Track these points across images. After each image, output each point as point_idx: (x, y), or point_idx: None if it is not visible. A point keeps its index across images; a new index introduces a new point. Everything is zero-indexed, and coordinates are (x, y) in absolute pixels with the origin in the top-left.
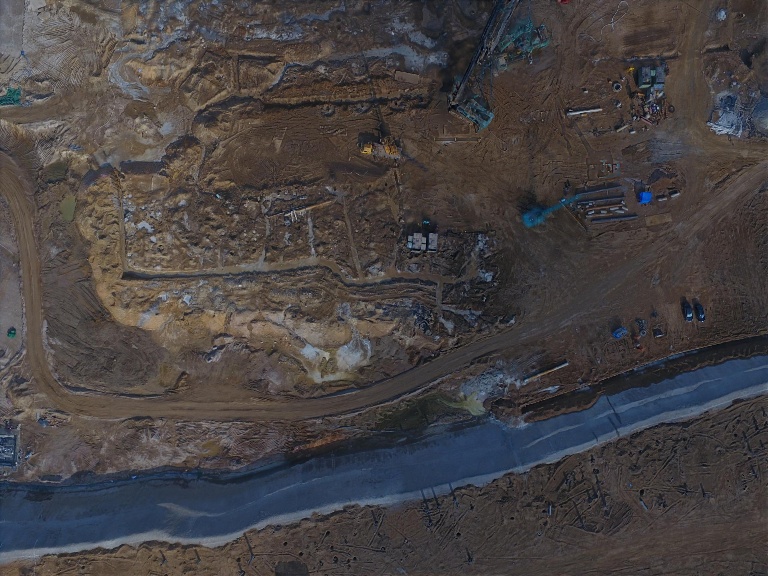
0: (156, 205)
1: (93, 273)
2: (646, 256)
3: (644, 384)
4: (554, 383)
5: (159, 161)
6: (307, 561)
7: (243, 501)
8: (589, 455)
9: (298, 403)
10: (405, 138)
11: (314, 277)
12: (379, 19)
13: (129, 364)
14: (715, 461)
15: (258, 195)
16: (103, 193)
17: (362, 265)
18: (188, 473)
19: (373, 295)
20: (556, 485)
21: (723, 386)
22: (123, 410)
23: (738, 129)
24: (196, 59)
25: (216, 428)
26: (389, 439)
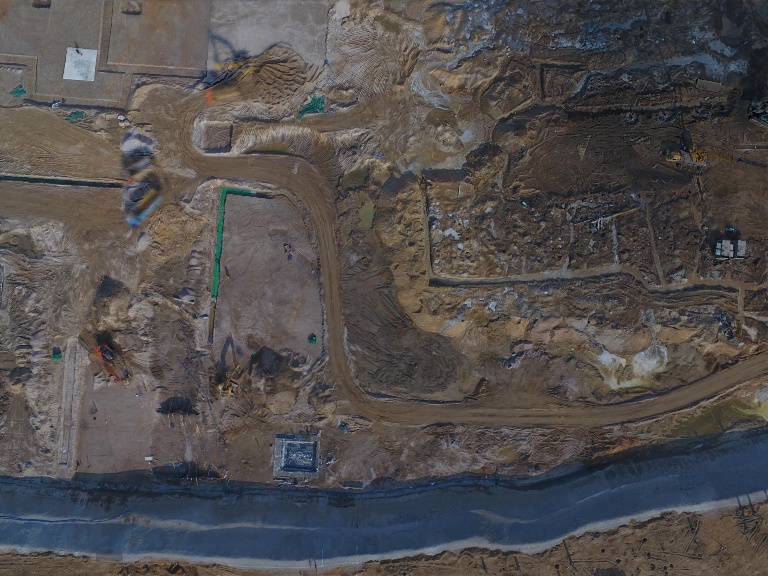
0: (463, 212)
1: (395, 280)
2: None
3: None
4: None
5: (460, 169)
6: (625, 568)
7: (553, 508)
8: None
9: (596, 409)
10: (706, 146)
11: (618, 284)
12: (680, 28)
13: (430, 370)
14: None
15: (563, 202)
16: (412, 200)
17: (665, 272)
18: (486, 479)
19: (678, 302)
20: None
21: None
22: (424, 416)
23: None
24: (500, 68)
25: (516, 434)
26: (685, 446)
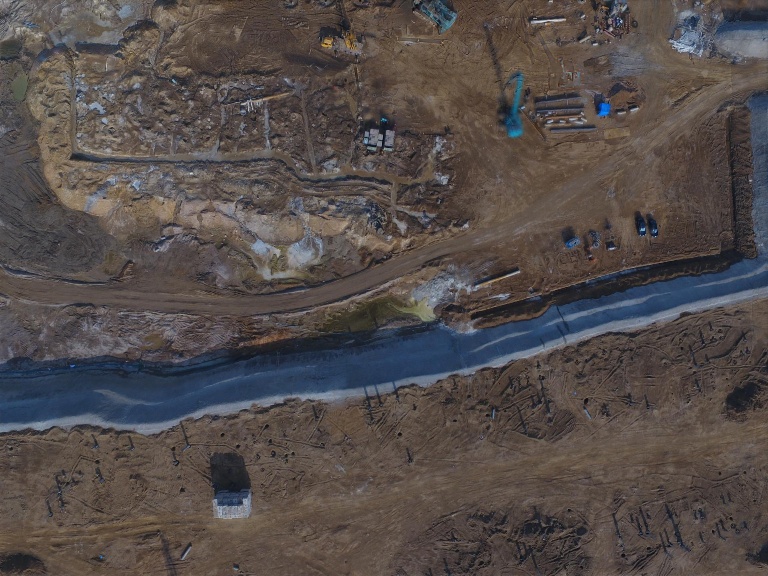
0: (110, 86)
1: (41, 154)
2: (603, 169)
3: (595, 296)
4: (505, 290)
5: (116, 44)
6: (244, 453)
7: (182, 392)
8: (535, 361)
9: (246, 299)
10: (367, 35)
11: (268, 169)
12: None
13: (73, 249)
14: (660, 373)
15: (215, 83)
16: (55, 70)
17: (317, 160)
18: (129, 365)
19: (327, 191)
20: (501, 389)
21: (672, 299)
22: (65, 296)
23: (699, 48)
24: None
25: (160, 319)
26: (337, 341)
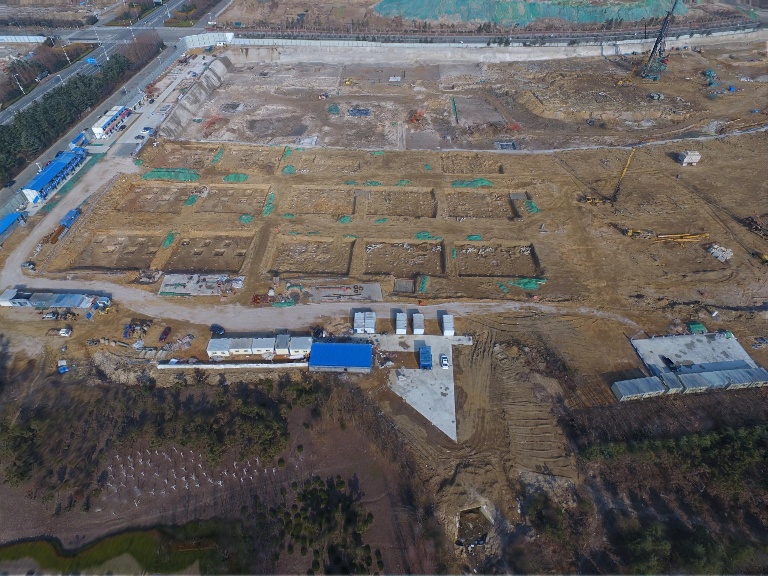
0: None
1: None
2: None
3: None
4: None
5: None
6: (677, 152)
7: None
8: None
9: None
10: None
11: None
12: None
13: None
14: None
15: None
16: None
17: None
18: None
19: None
20: None
21: None
22: None
23: (750, 80)
24: None
25: None
26: None
